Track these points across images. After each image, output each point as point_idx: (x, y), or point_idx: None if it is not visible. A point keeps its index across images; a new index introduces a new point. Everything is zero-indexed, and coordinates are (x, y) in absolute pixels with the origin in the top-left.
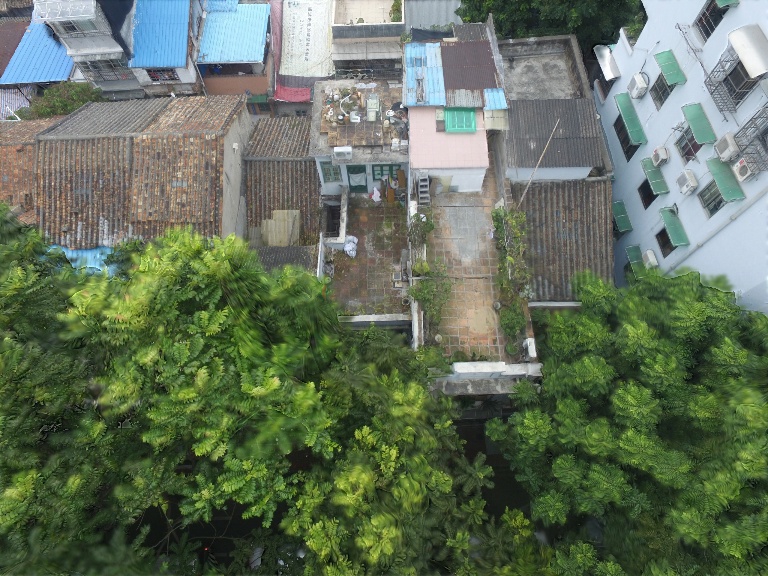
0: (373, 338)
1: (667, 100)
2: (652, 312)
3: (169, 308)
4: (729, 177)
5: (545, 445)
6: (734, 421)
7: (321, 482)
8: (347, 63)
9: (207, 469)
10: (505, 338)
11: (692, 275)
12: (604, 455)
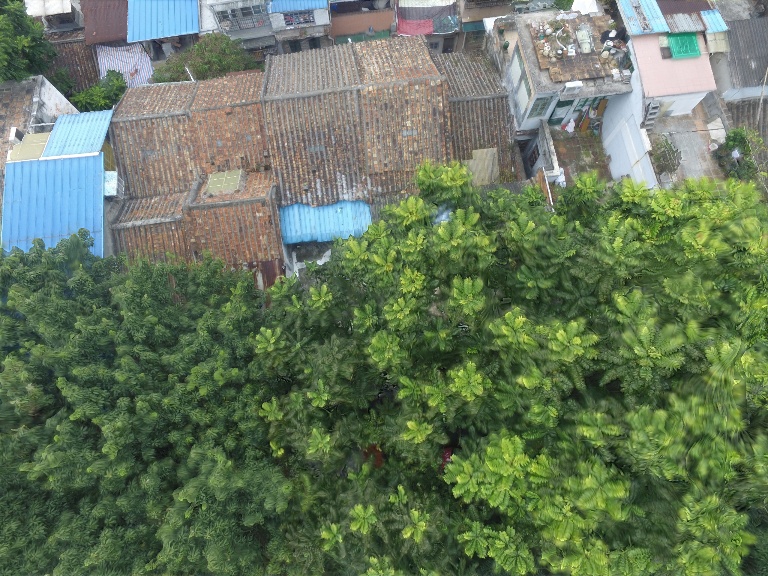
0: None
1: None
2: None
3: None
4: None
5: None
6: None
7: None
8: None
9: None
10: None
11: None
12: None
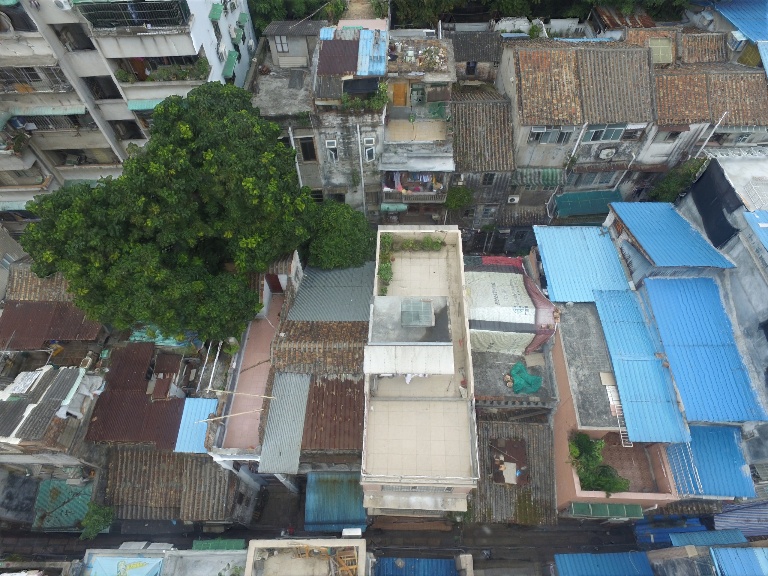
0: None
1: None
2: None
3: None
4: None
5: None
6: None
7: None
8: None
9: None
10: None
11: None
12: None
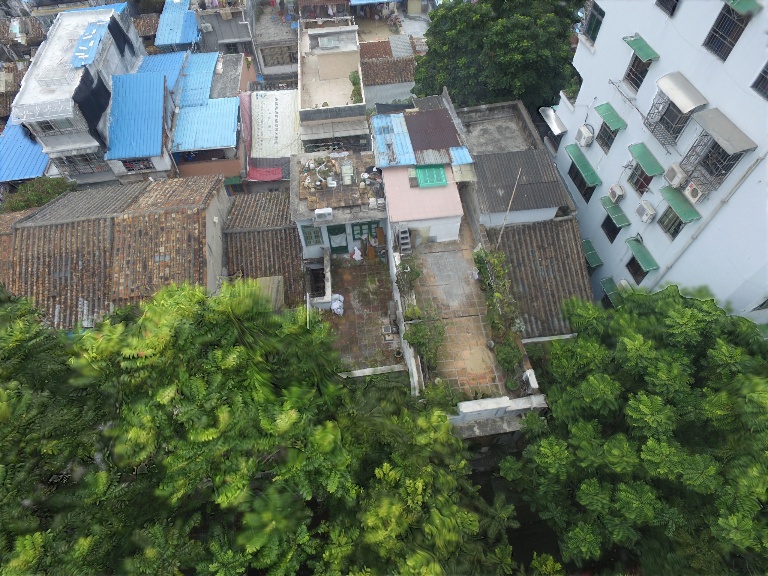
0: (377, 381)
1: (613, 144)
2: (642, 326)
3: (184, 341)
4: (683, 201)
5: (565, 472)
6: (747, 410)
7: (347, 527)
8: (315, 142)
9: (226, 519)
10: (503, 375)
11: (671, 288)
12: (627, 471)
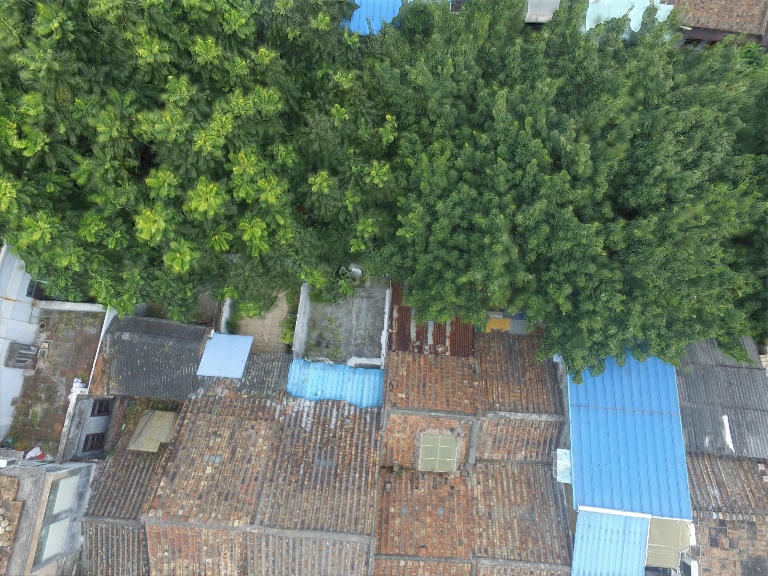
0: None
1: None
2: None
3: None
4: None
5: None
6: None
7: None
8: None
9: None
10: None
11: None
12: None
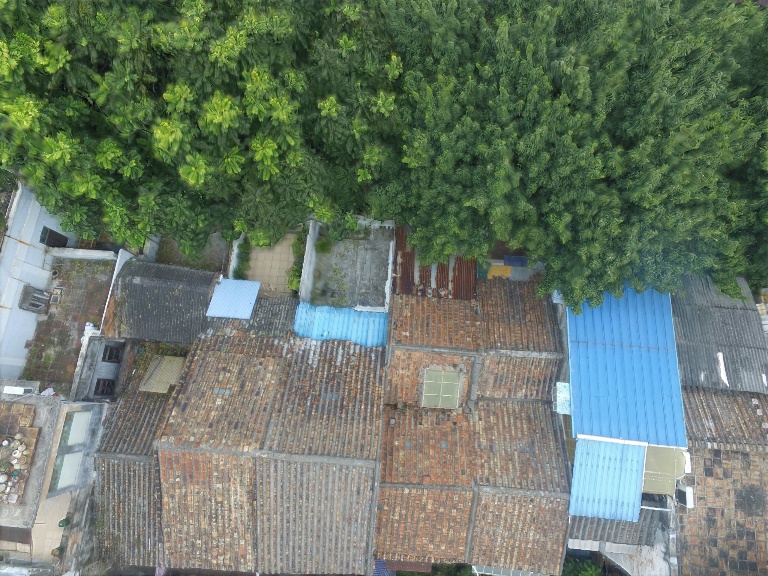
0: (2, 146)
1: None
2: None
3: None
4: None
5: None
6: None
7: None
8: None
9: None
10: None
11: None
12: None
